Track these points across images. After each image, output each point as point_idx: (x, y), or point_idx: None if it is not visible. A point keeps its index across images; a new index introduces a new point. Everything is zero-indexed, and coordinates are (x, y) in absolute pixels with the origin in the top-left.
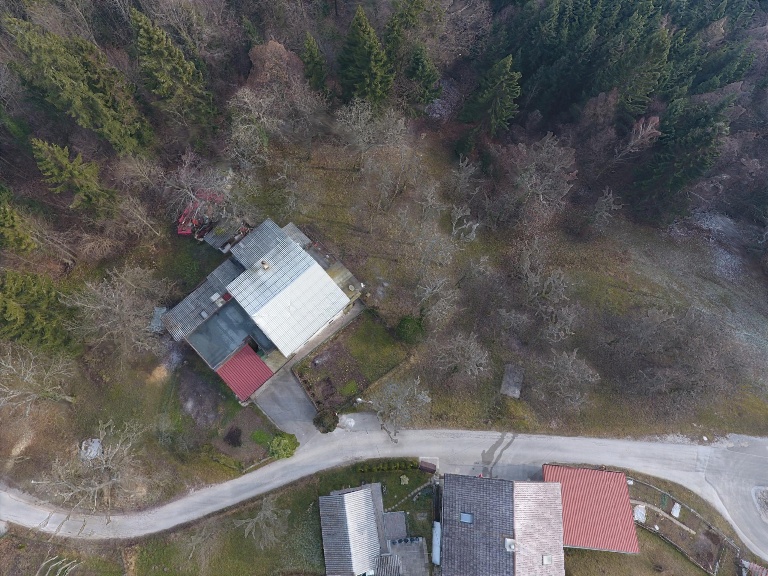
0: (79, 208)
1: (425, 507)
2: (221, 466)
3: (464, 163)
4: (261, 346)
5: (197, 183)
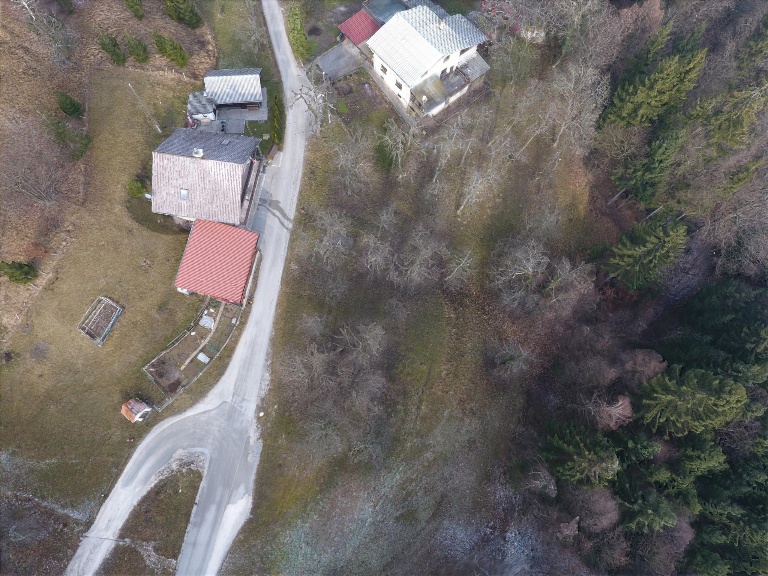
0: None
1: None
2: None
3: None
4: None
5: None
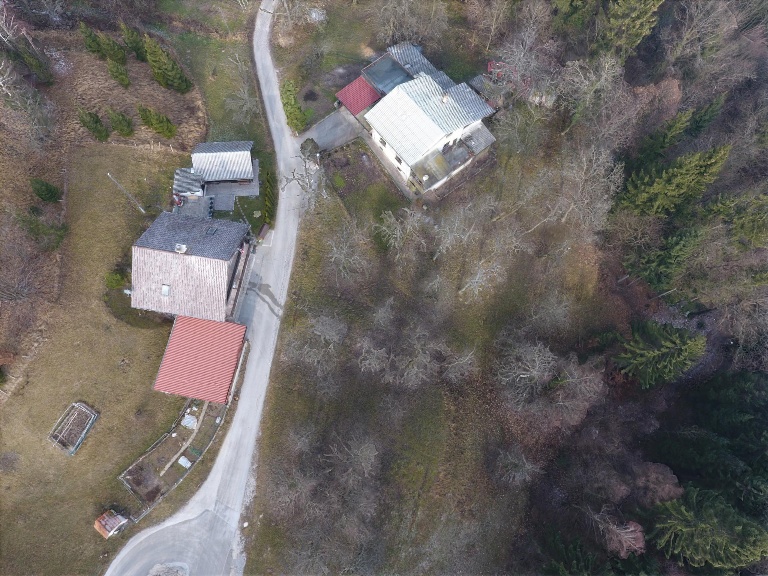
0: None
1: None
2: None
3: None
4: None
5: None
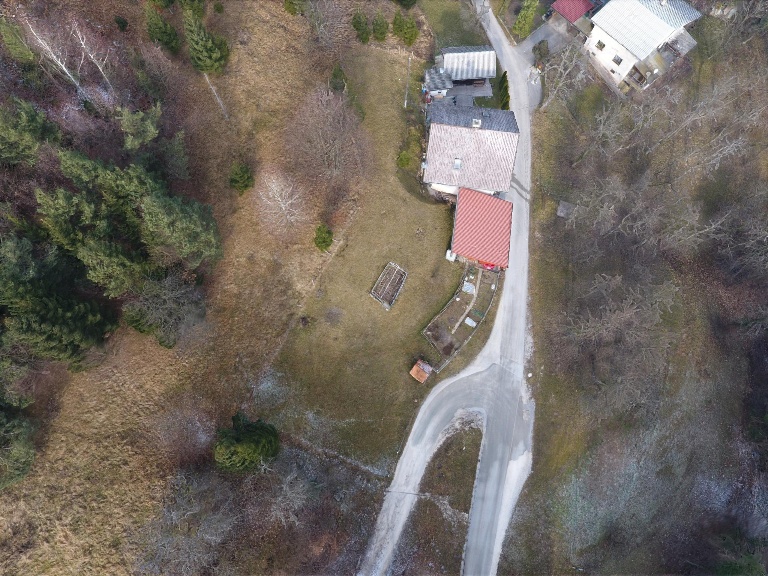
0: None
1: None
2: (501, 4)
3: None
4: (595, 9)
5: None
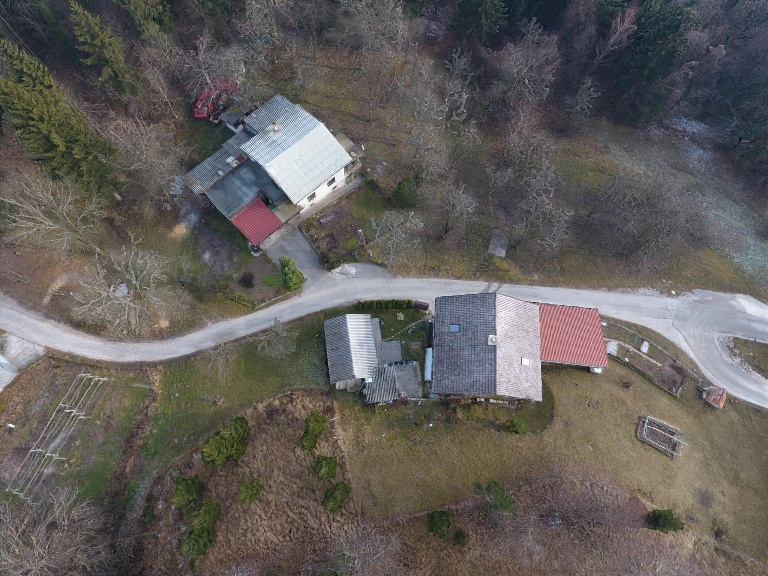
0: (106, 85)
1: (419, 338)
2: (236, 304)
3: (456, 54)
4: (272, 198)
5: (213, 66)
